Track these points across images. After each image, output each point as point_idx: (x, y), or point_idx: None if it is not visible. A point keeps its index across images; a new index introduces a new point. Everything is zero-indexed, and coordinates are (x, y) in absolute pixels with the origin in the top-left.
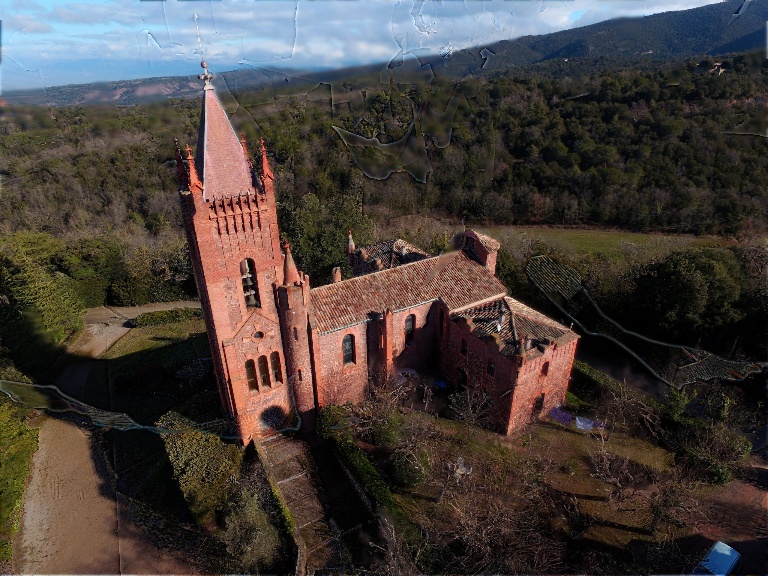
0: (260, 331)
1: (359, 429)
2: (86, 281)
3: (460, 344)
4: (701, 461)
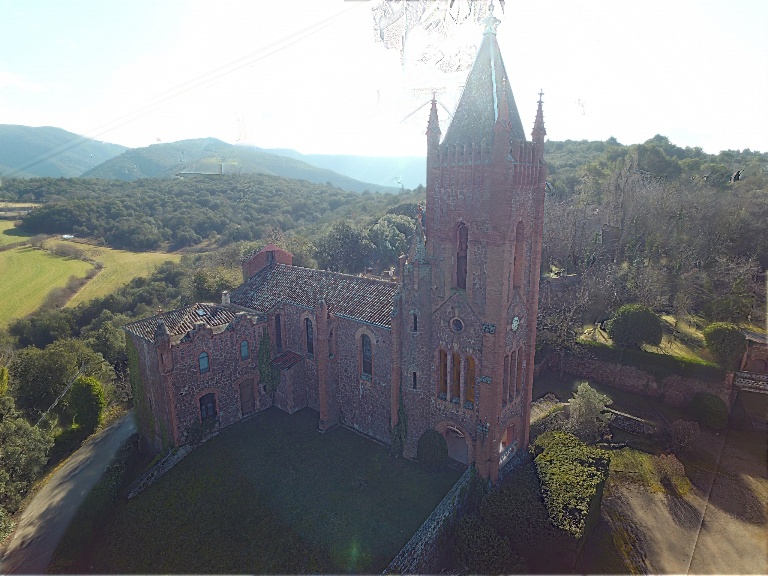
0: None
1: None
2: None
3: None
4: None
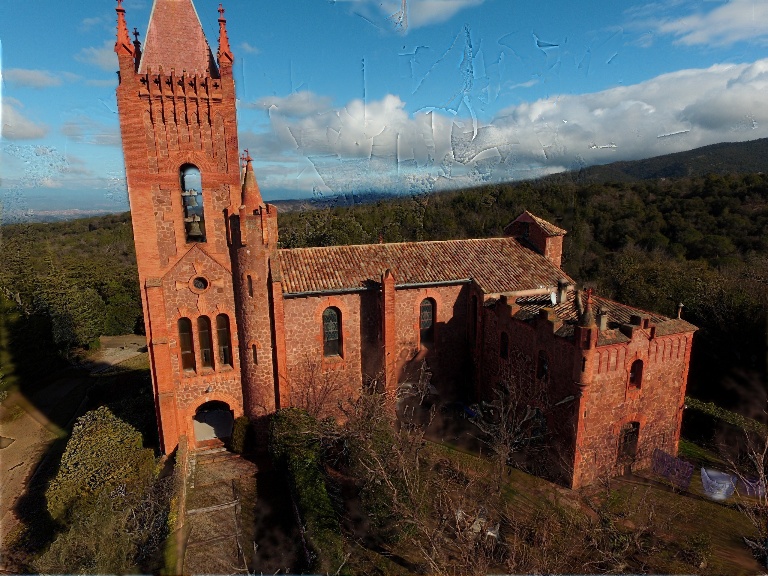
0: (203, 277)
1: (318, 434)
2: (120, 307)
3: (499, 342)
4: None
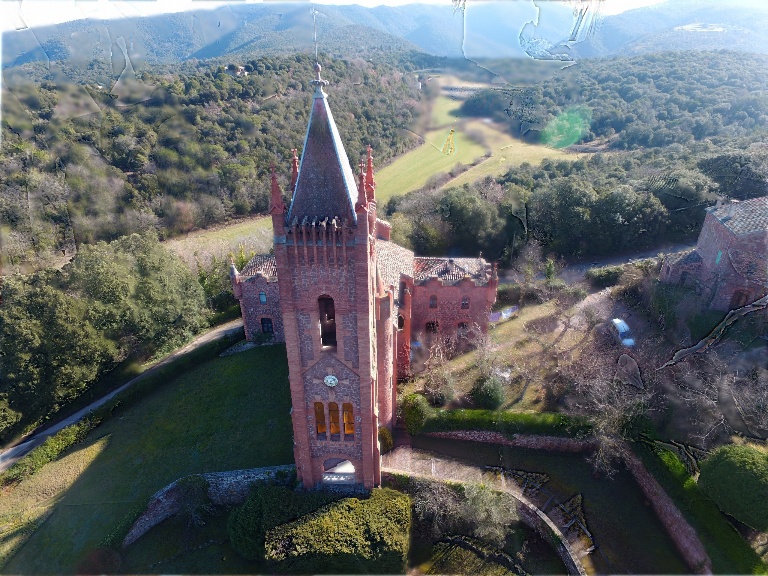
0: None
1: (455, 391)
2: None
3: (429, 301)
4: (575, 293)
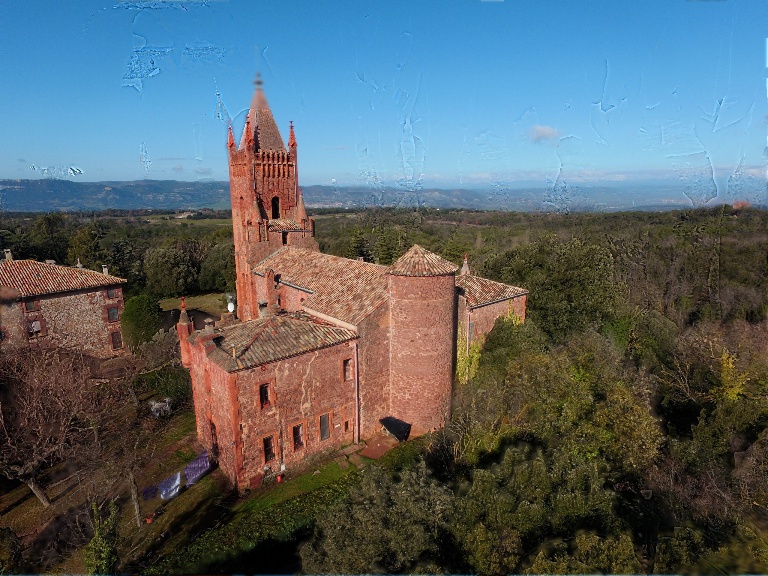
0: None
1: None
2: None
3: None
4: None
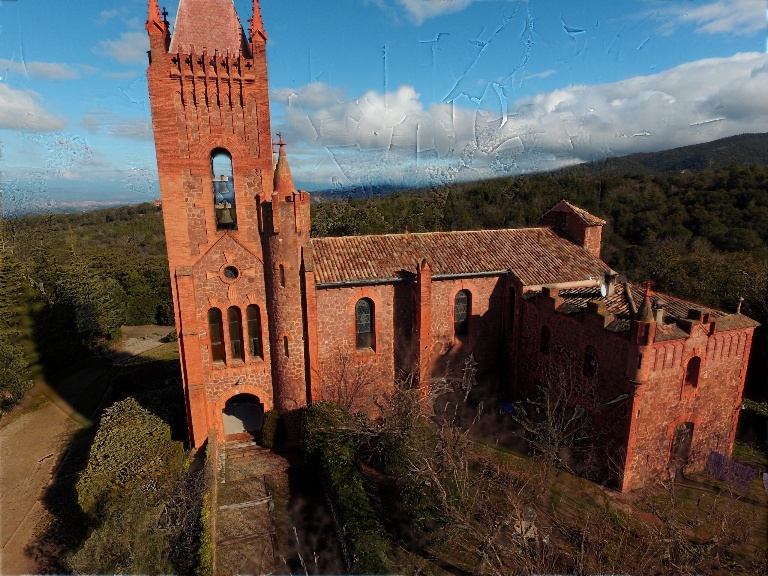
0: (234, 266)
1: (355, 431)
2: (140, 297)
3: (539, 337)
4: None
